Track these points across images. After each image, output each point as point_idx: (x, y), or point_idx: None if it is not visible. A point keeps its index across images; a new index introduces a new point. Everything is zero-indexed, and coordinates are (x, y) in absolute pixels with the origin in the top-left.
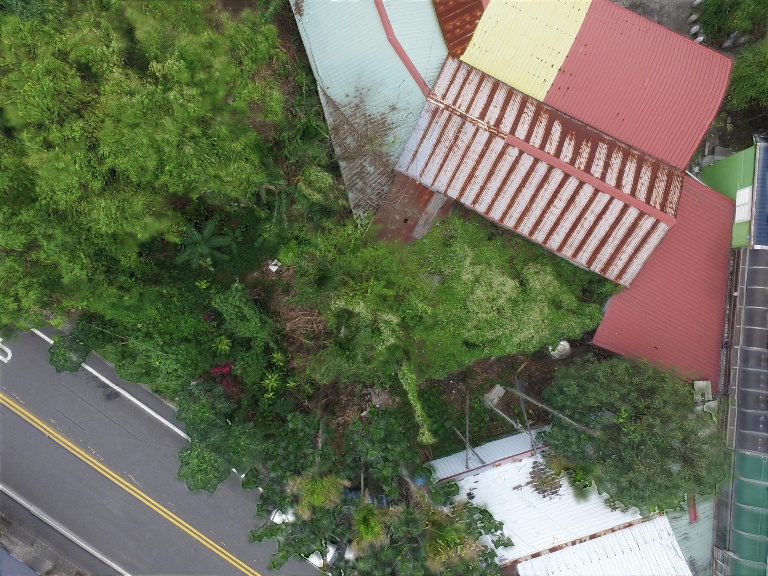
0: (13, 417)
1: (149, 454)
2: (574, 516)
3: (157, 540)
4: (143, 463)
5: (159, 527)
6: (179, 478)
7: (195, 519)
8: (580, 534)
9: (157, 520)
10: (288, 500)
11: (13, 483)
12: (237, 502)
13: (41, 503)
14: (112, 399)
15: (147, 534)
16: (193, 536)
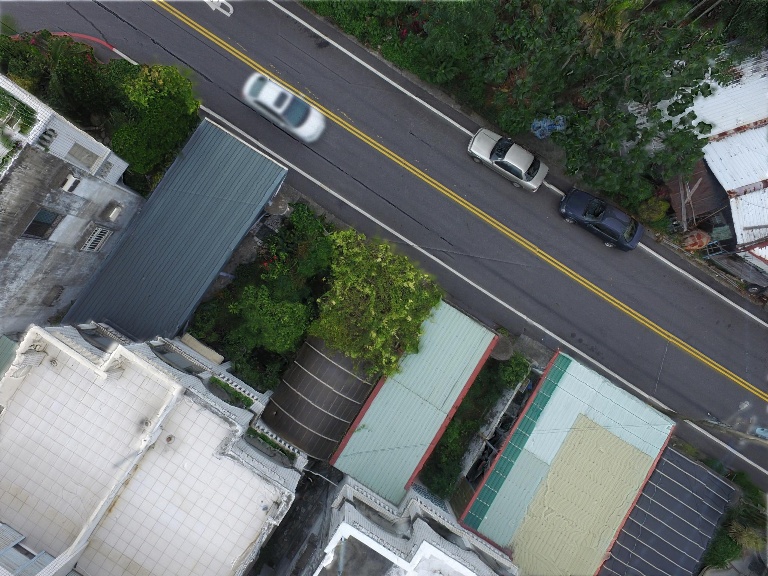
0: (238, 63)
1: (358, 94)
2: (754, 101)
3: (369, 168)
4: (353, 102)
5: (370, 157)
6: (385, 115)
7: (401, 149)
8: (760, 116)
9: (368, 150)
10: (530, 36)
11: (241, 121)
12: (436, 136)
13: (266, 138)
14: (323, 47)
15: (360, 163)
16: (400, 164)
